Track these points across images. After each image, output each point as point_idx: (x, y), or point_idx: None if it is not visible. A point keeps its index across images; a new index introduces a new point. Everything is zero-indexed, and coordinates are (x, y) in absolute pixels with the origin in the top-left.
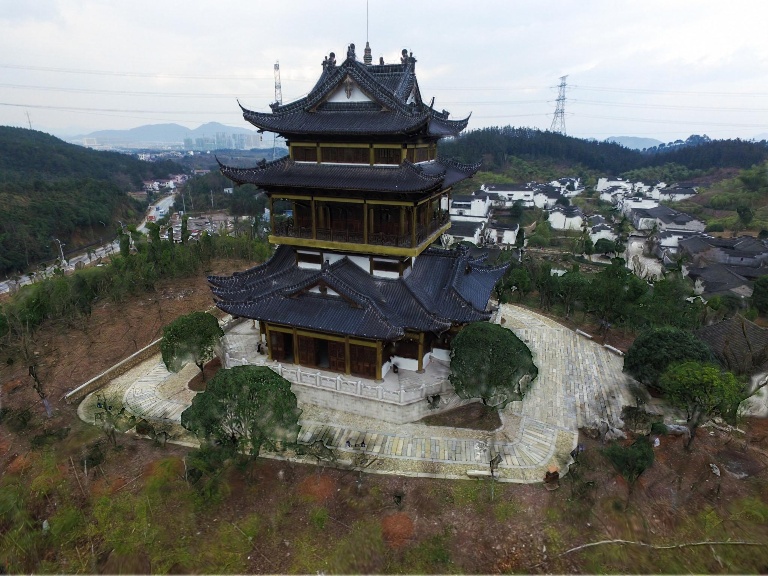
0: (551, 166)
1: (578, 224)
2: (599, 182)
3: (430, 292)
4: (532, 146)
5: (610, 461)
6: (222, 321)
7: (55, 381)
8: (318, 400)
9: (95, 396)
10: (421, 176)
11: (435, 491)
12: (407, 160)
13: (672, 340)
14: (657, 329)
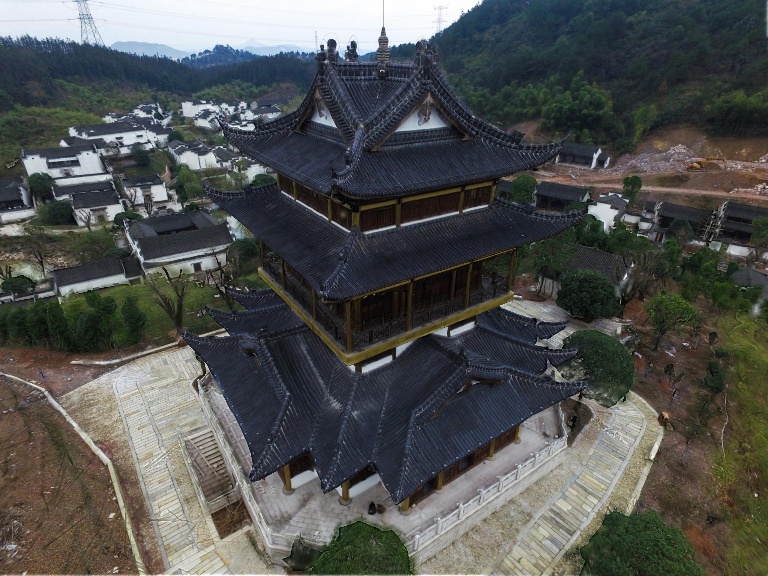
0: (115, 90)
1: (214, 161)
2: (183, 106)
3: (486, 325)
4: (78, 65)
5: (704, 388)
6: (162, 521)
7: None
8: (498, 504)
9: None
10: (535, 216)
11: (670, 491)
12: None
13: (594, 280)
14: (580, 275)
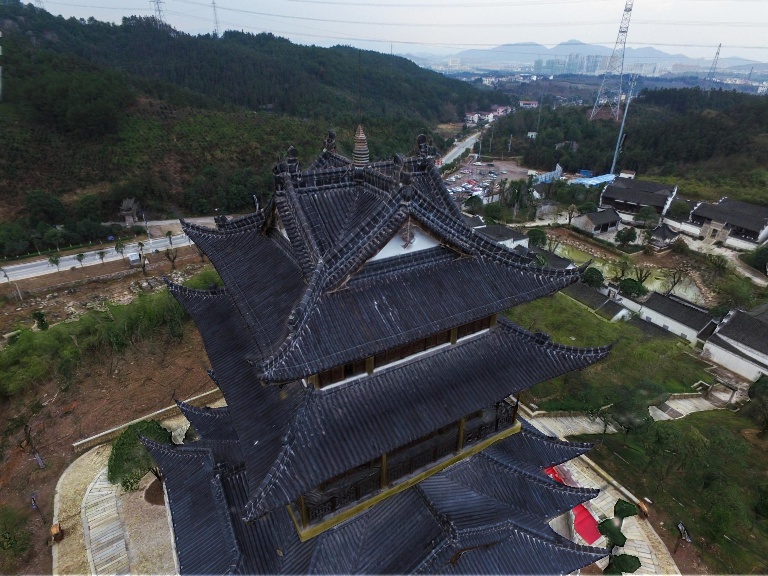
0: None
1: None
2: None
3: (361, 573)
4: None
5: None
6: None
7: (87, 419)
8: None
9: (96, 452)
10: None
11: None
12: (309, 390)
13: None
14: None
